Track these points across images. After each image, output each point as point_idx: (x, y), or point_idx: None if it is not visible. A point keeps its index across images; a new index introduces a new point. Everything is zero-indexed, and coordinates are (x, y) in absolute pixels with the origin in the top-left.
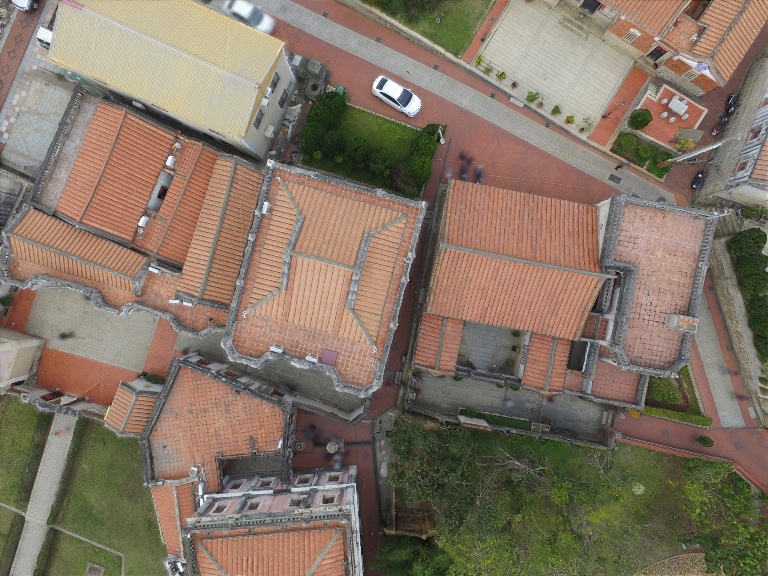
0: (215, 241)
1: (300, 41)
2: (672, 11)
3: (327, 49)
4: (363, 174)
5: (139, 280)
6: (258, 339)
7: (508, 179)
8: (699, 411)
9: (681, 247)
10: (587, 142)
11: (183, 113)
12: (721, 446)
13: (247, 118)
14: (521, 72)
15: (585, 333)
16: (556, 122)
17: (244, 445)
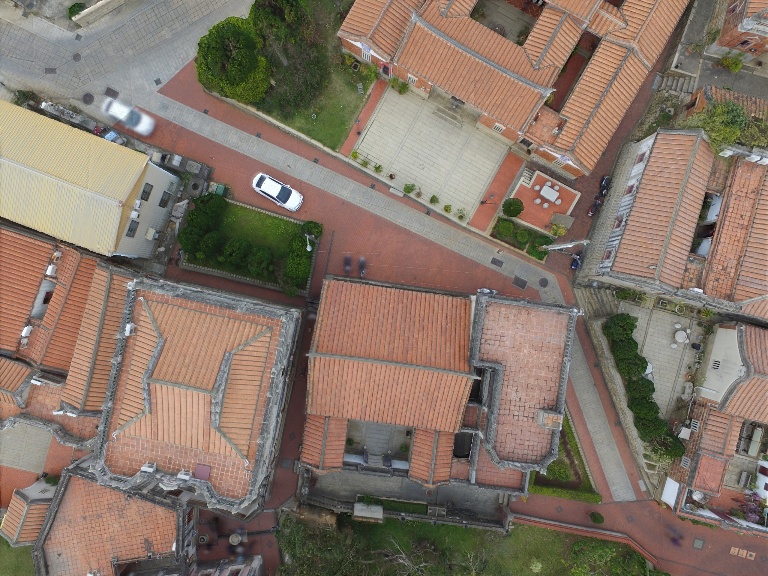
0: (95, 352)
1: (183, 138)
2: (530, 108)
3: (209, 146)
4: (249, 270)
5: (20, 395)
6: (131, 458)
7: (392, 267)
8: (591, 487)
9: (546, 342)
10: (468, 228)
11: (51, 231)
12: (614, 520)
13: (114, 235)
14: (399, 163)
15: (468, 422)
16: (436, 210)
17: (139, 548)
